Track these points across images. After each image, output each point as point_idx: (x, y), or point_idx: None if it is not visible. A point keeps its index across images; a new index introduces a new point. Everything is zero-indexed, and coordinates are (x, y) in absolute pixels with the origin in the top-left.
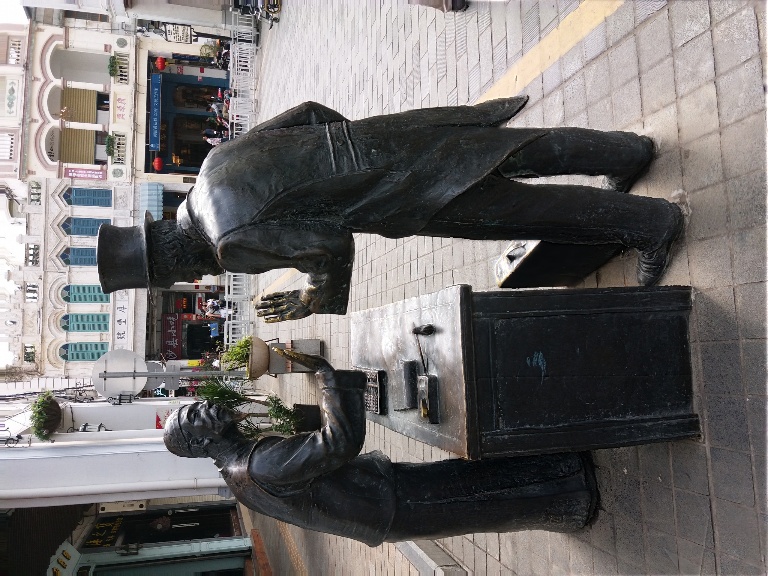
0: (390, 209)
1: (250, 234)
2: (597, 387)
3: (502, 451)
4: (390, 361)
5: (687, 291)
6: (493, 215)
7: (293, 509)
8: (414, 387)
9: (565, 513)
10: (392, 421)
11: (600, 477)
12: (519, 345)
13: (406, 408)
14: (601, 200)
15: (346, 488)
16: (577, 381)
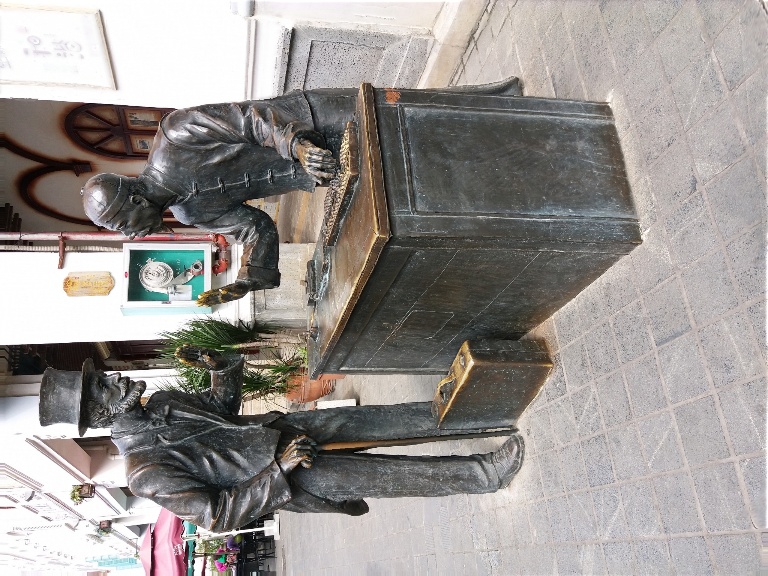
0: None
1: None
2: None
3: None
4: None
5: None
6: None
7: None
8: None
9: None
10: None
11: None
12: None
13: None
14: None
15: None
16: None
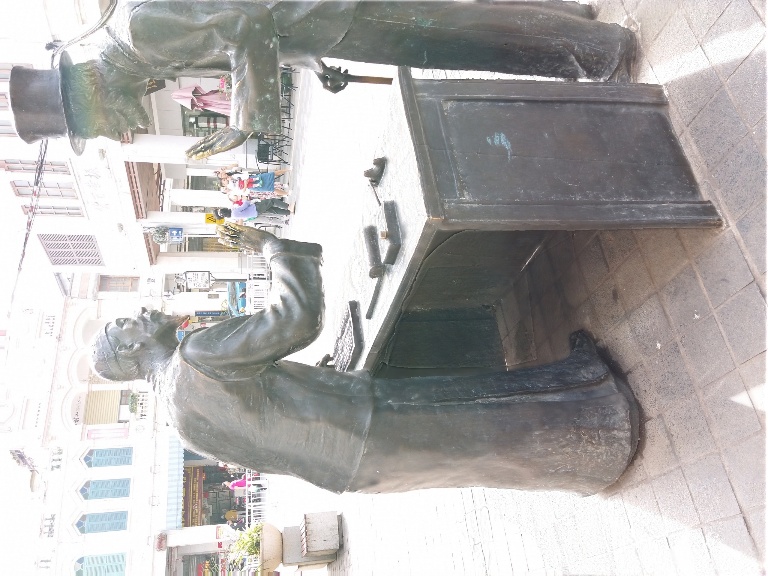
0: (313, 1)
1: (160, 5)
2: (578, 170)
3: (472, 219)
4: None
5: (658, 88)
6: (425, 14)
7: (238, 402)
8: (377, 248)
9: (600, 426)
10: (367, 341)
11: (634, 381)
12: (475, 126)
13: (369, 269)
14: (539, 9)
15: (308, 384)
16: (552, 162)
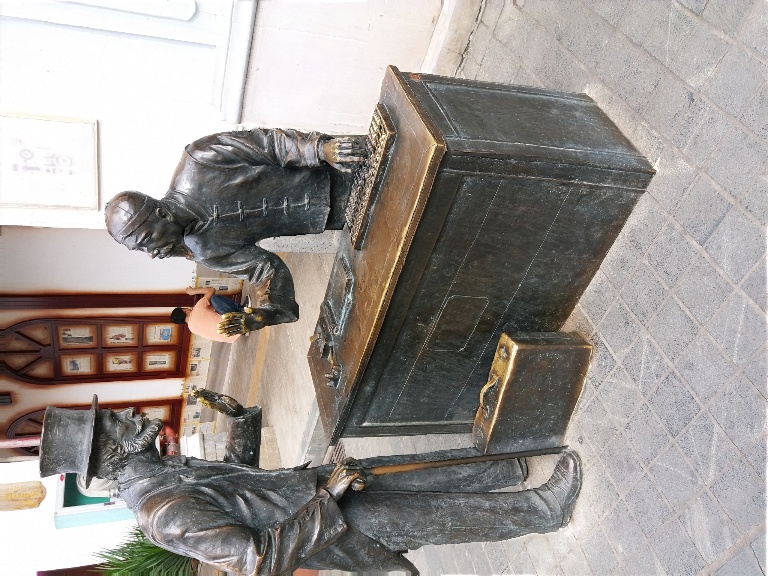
0: None
1: None
2: None
3: None
4: None
5: None
6: None
7: None
8: None
9: None
10: (344, 234)
11: None
12: None
13: None
14: None
15: None
16: None
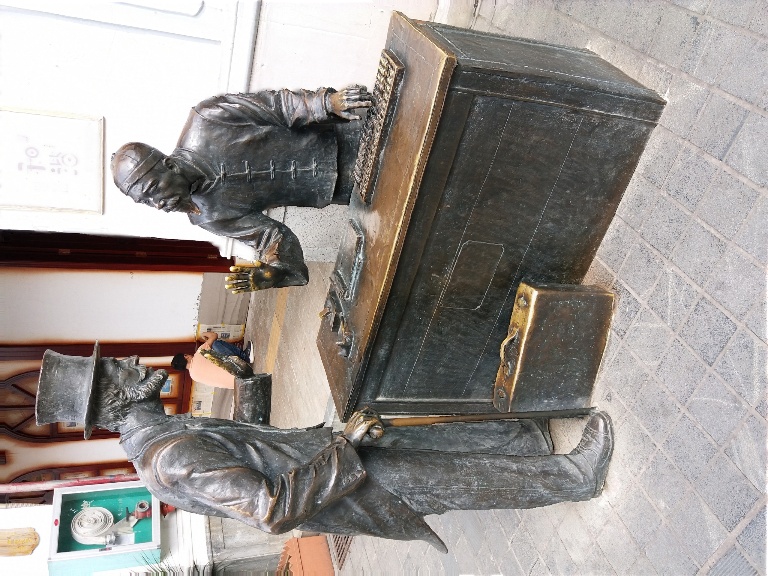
0: None
1: None
2: None
3: None
4: (369, 228)
5: None
6: None
7: None
8: None
9: None
10: (353, 197)
11: None
12: None
13: None
14: None
15: None
16: None
